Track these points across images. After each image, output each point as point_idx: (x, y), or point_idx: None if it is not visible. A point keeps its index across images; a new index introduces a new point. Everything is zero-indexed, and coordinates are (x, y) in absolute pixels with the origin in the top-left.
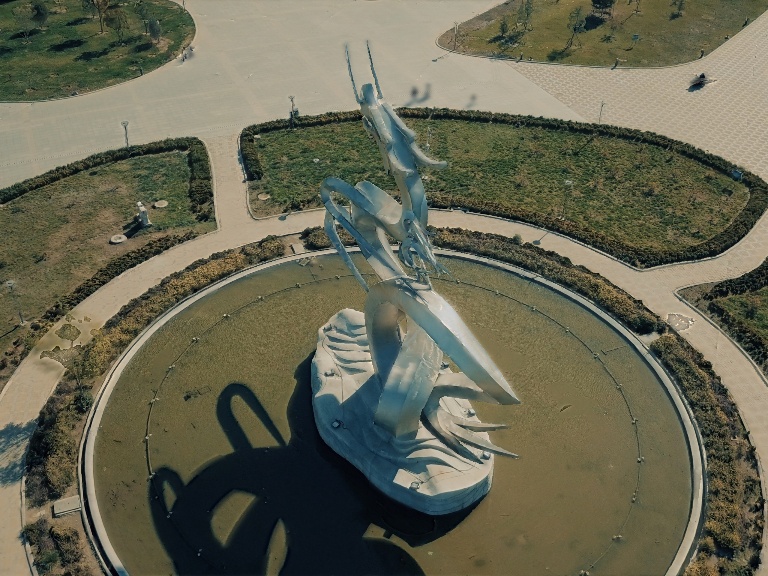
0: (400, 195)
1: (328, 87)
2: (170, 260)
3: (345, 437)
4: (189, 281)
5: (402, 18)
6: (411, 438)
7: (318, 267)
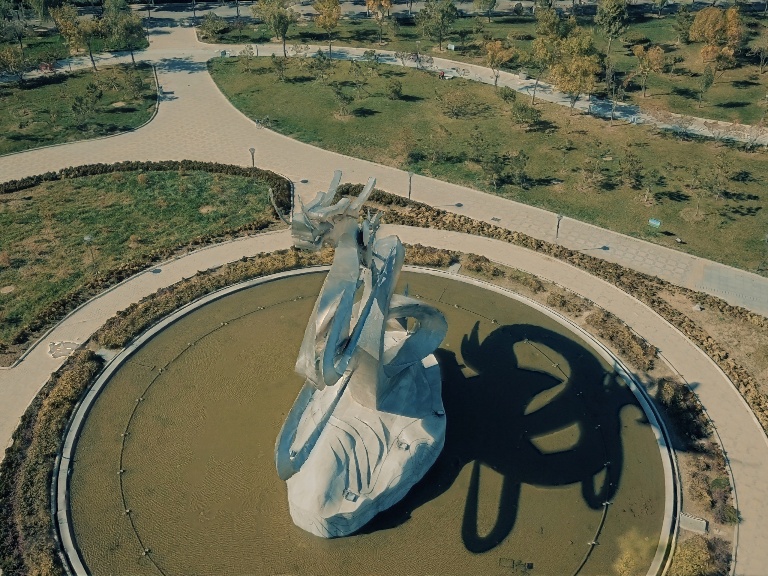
0: None
1: None
2: None
3: (440, 407)
4: None
5: None
6: None
7: None
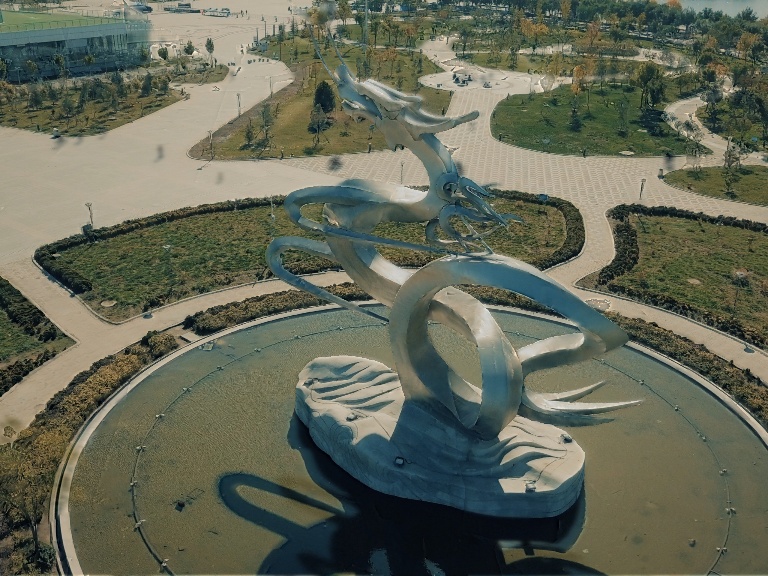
0: (260, 272)
1: (104, 204)
2: (39, 384)
3: (417, 471)
4: (88, 393)
5: (136, 144)
6: (495, 442)
7: (228, 347)
